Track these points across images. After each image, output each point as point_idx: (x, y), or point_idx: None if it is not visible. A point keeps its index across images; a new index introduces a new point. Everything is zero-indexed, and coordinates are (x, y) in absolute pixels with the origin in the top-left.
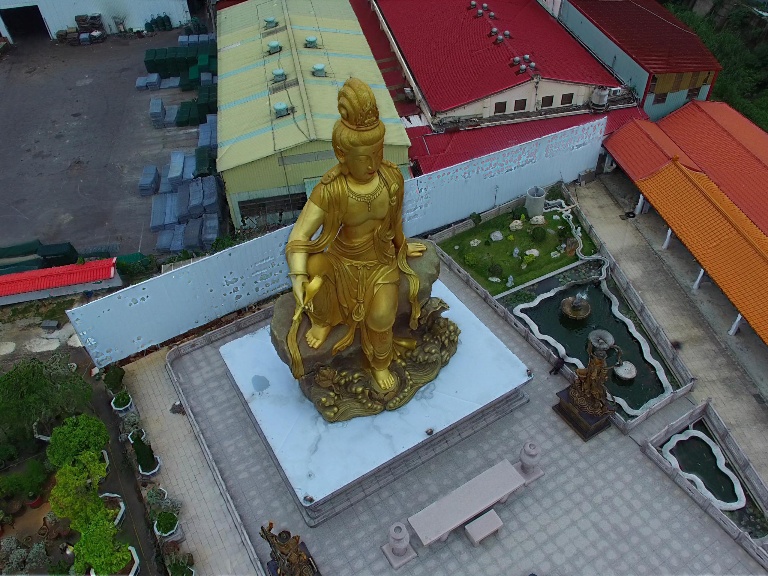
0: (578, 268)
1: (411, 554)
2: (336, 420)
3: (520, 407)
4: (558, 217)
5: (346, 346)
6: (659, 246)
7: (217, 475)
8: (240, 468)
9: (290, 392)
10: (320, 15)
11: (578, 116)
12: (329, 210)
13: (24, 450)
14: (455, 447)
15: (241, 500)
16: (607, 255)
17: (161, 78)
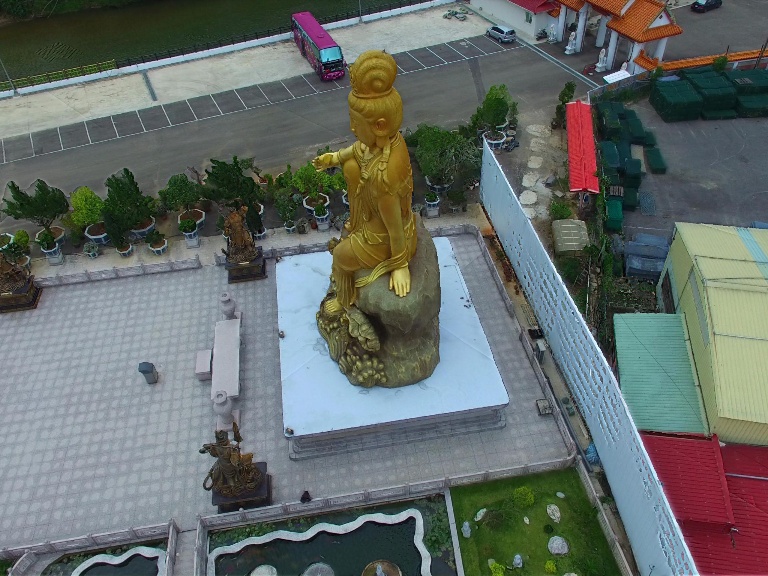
0: None
1: None
2: None
3: None
4: None
5: None
6: None
7: None
8: None
9: None
10: None
11: None
12: None
13: None
14: None
15: None
16: None
17: None
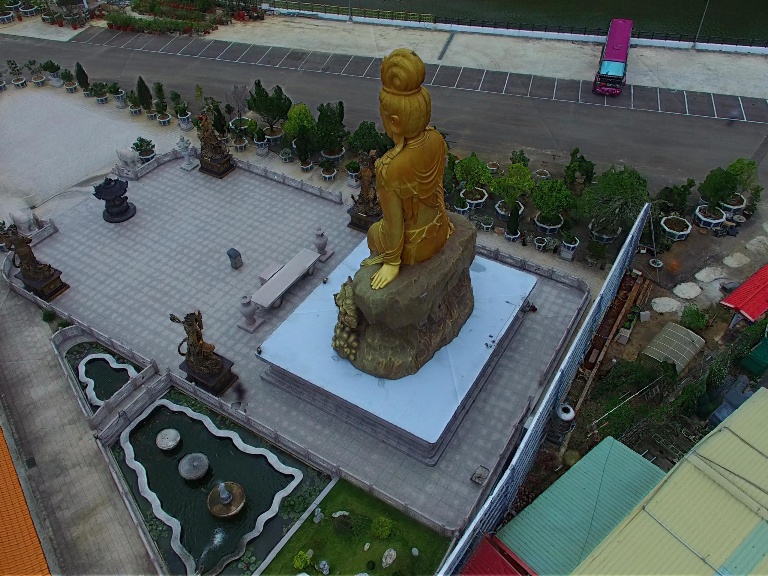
0: None
1: None
2: None
3: None
4: None
5: None
6: None
7: None
8: None
9: None
10: None
11: None
12: None
13: None
14: None
15: None
16: None
17: None
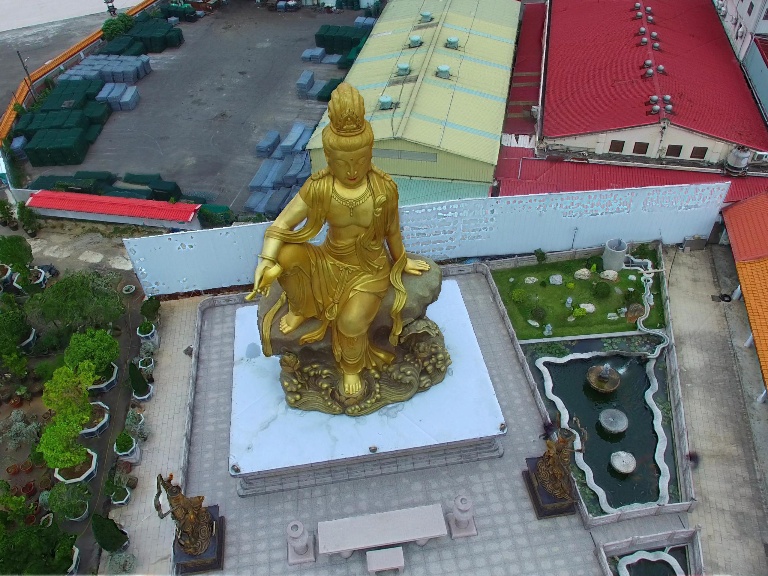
0: (632, 338)
1: (309, 556)
2: (297, 407)
3: (489, 459)
4: (634, 278)
5: (315, 340)
6: (741, 342)
7: (186, 419)
8: (211, 421)
9: (273, 367)
10: (480, 17)
11: (705, 174)
12: (313, 205)
13: (64, 345)
14: (404, 474)
15: (197, 449)
16: (669, 333)
17: (326, 53)
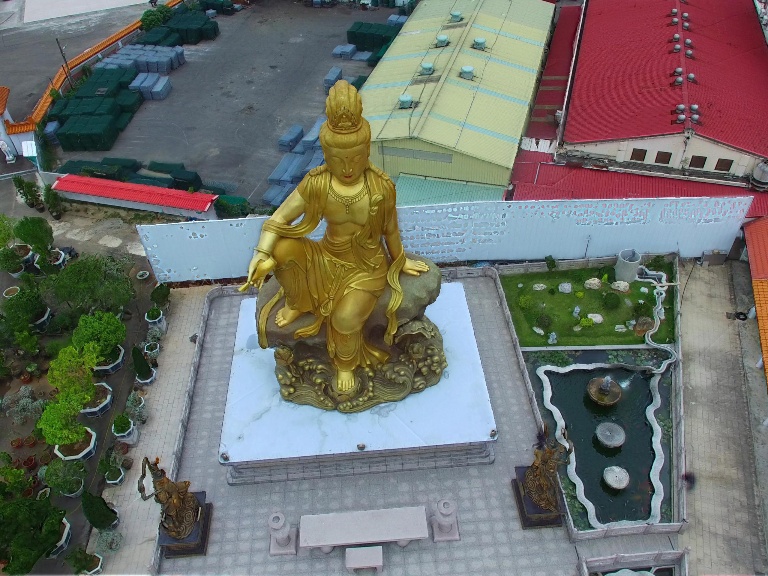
0: (639, 352)
1: (290, 549)
2: (291, 400)
3: (479, 465)
4: (646, 290)
5: (309, 335)
6: (753, 362)
7: (185, 405)
8: (208, 408)
9: (271, 360)
10: (511, 19)
11: (729, 187)
12: (310, 201)
13: (76, 325)
14: (393, 474)
15: (193, 435)
16: (677, 349)
17: (357, 50)
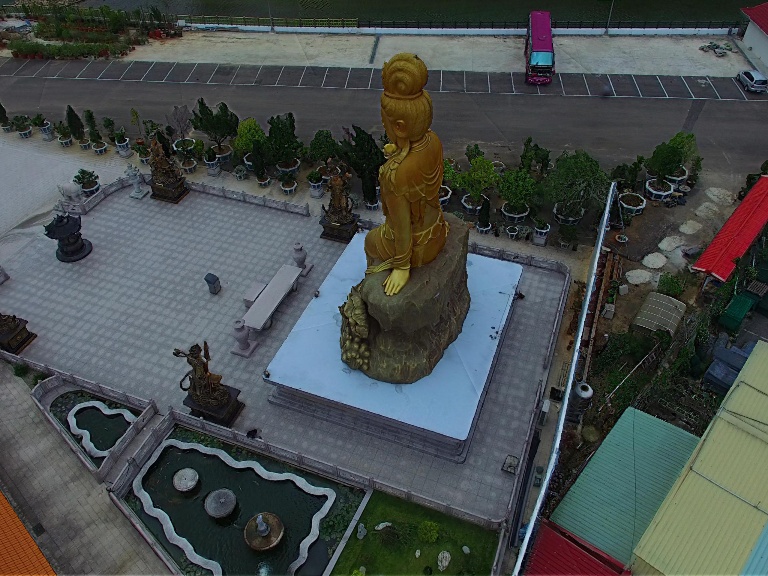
0: None
1: None
2: None
3: None
4: None
5: None
6: None
7: None
8: None
9: None
10: None
11: None
12: None
13: None
14: None
15: None
16: None
17: None
